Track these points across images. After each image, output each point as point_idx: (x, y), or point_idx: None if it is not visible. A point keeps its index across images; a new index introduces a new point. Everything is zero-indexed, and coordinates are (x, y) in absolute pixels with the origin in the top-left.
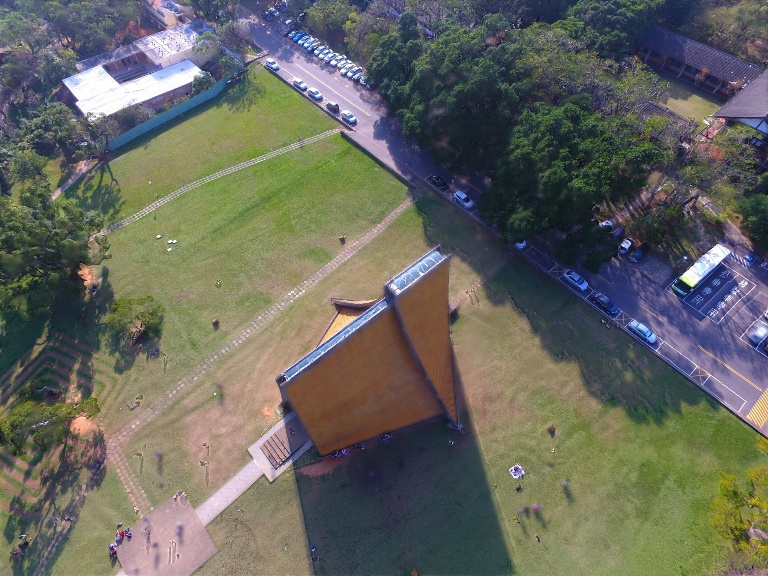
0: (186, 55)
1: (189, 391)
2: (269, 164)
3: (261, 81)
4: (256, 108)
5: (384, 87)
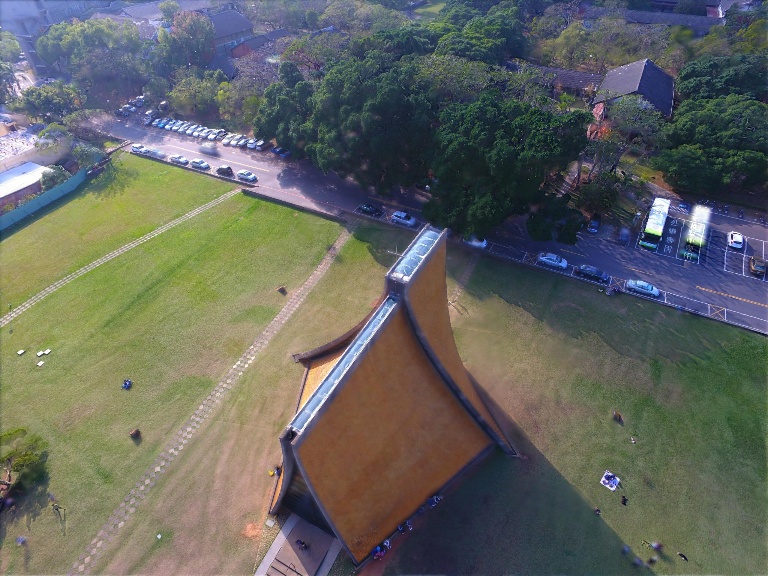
0: (27, 157)
1: (113, 548)
2: (163, 238)
3: (130, 166)
4: (131, 190)
5: (281, 132)
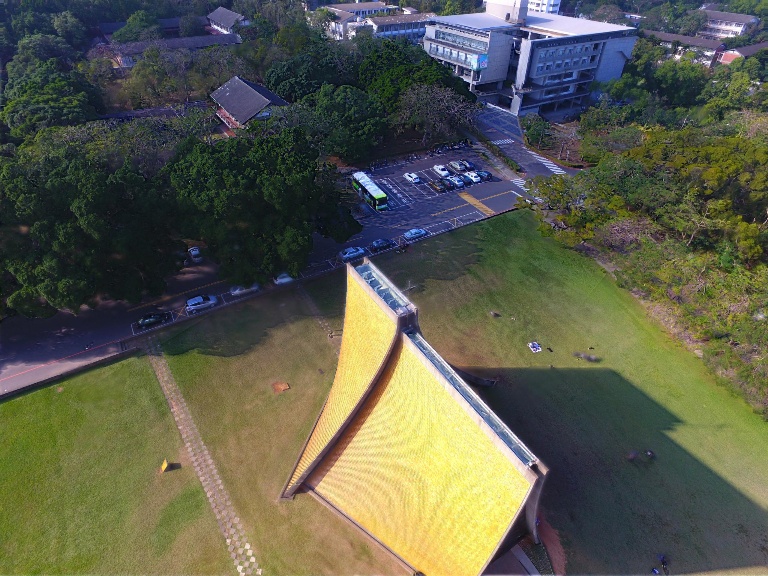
0: None
1: None
2: None
3: None
4: None
5: None
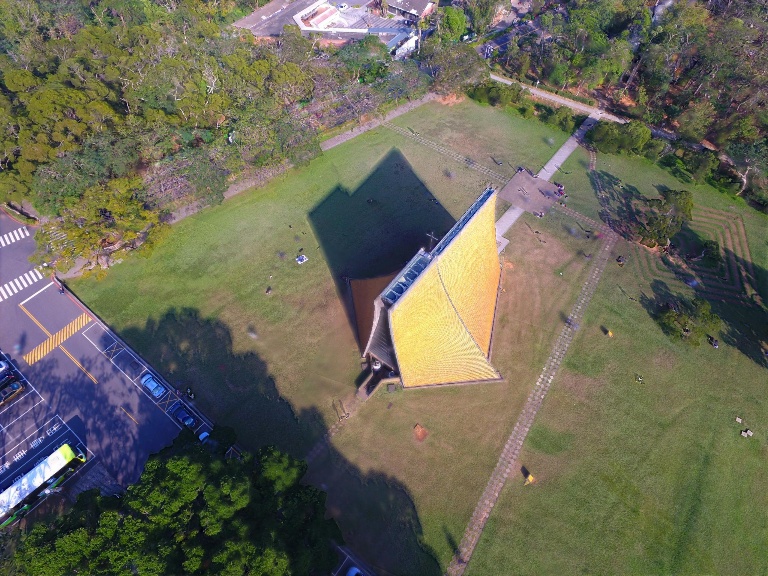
0: None
1: (585, 273)
2: None
3: None
4: None
5: None
